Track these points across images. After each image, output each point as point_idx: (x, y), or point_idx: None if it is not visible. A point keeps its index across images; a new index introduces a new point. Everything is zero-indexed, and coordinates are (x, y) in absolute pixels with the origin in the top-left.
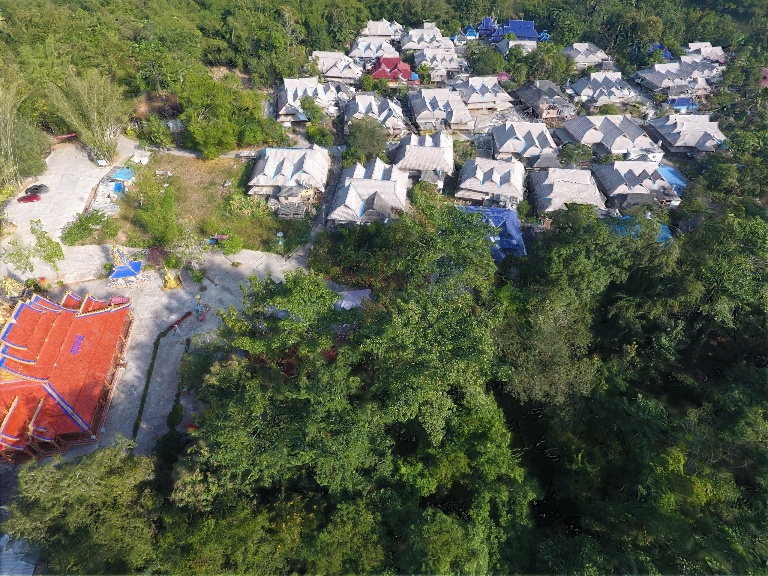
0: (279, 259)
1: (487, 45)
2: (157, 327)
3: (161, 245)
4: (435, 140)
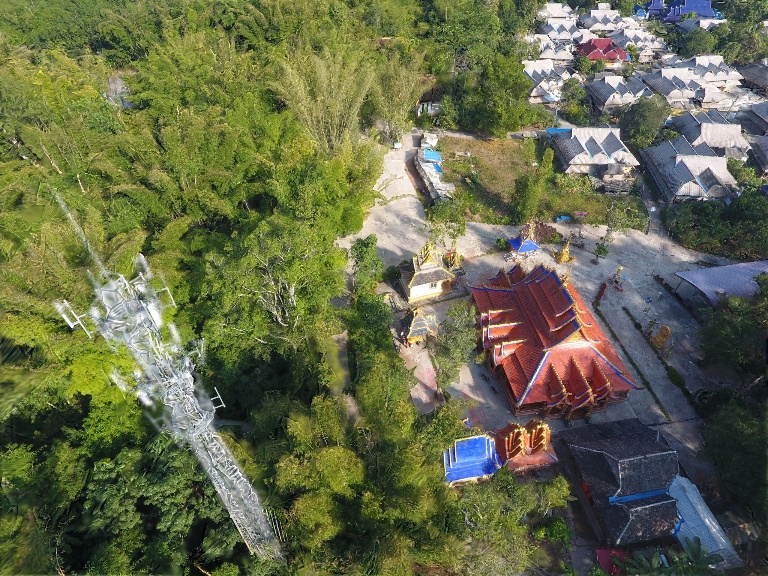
0: (640, 234)
1: (664, 25)
2: (584, 297)
3: (520, 222)
4: (714, 118)
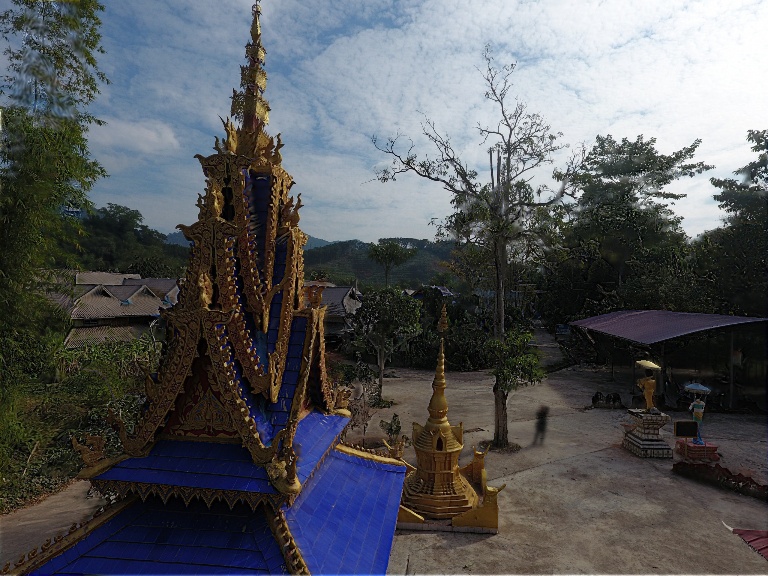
0: (395, 379)
1: None
2: None
3: None
4: None
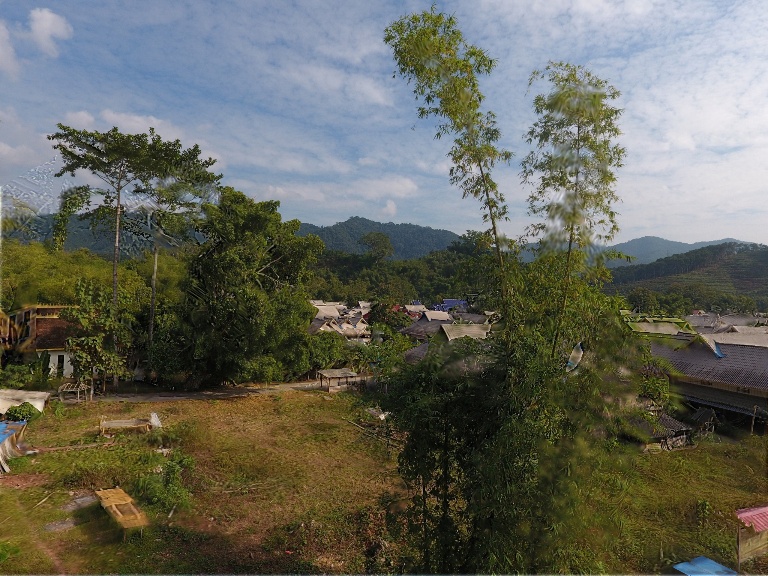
0: None
1: None
2: None
3: None
4: None
